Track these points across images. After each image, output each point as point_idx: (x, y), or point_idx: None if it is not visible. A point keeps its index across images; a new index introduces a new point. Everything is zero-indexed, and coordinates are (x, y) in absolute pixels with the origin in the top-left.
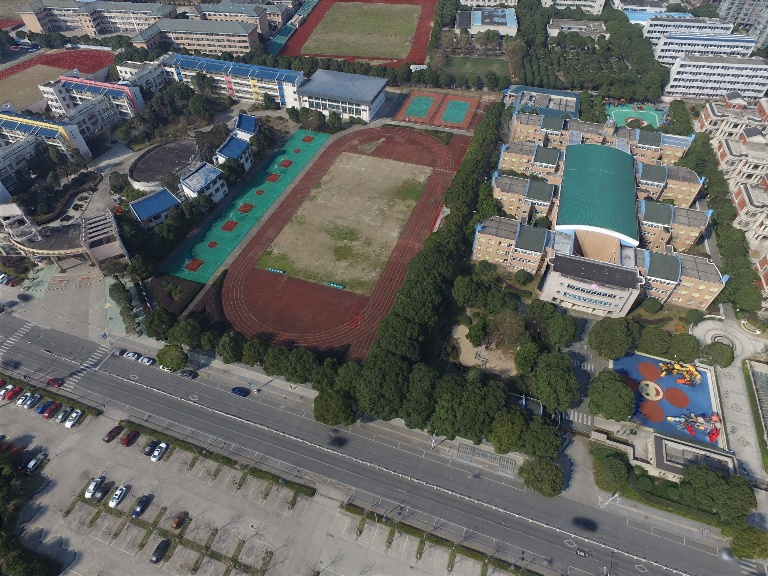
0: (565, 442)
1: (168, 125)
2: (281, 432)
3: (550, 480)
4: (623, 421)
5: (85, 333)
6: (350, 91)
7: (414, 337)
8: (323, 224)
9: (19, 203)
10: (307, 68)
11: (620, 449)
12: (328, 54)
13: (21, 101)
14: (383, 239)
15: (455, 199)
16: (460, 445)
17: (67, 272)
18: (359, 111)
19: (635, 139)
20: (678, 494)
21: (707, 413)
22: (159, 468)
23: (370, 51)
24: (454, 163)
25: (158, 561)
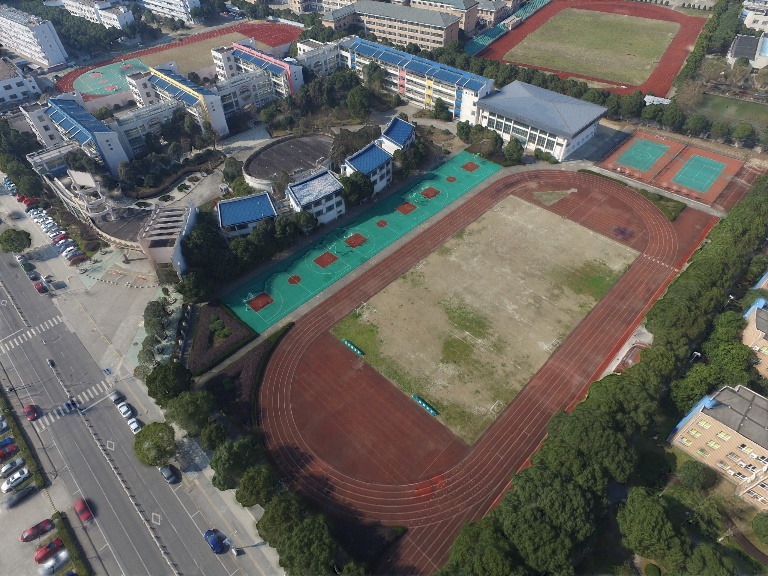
0: None
1: (319, 115)
2: None
3: None
4: None
5: (100, 353)
6: (548, 115)
7: None
8: (445, 295)
9: (127, 170)
10: (502, 77)
11: None
12: (536, 65)
13: (201, 64)
14: (525, 349)
15: (668, 324)
16: None
17: (130, 264)
18: (552, 144)
19: None
20: None
21: None
22: None
23: (592, 69)
24: (677, 253)
25: None
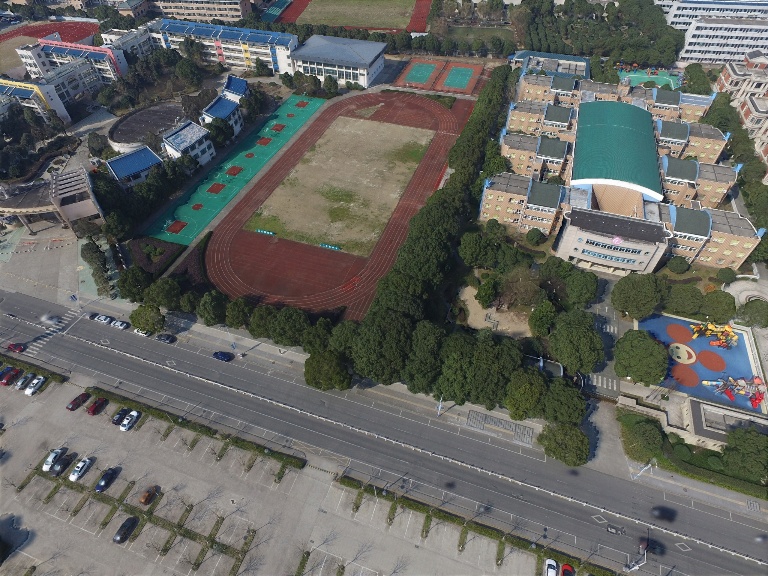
0: (588, 408)
1: (154, 91)
2: (268, 399)
3: (575, 447)
4: (653, 385)
5: (53, 296)
6: (347, 54)
7: (417, 294)
8: (317, 186)
9: None
10: (302, 35)
11: (651, 415)
12: None
13: None
14: (382, 200)
15: (460, 158)
16: (470, 412)
17: (37, 235)
18: (356, 76)
19: (652, 98)
20: (721, 464)
21: (747, 377)
22: (129, 438)
23: (368, 22)
24: (458, 126)
25: (123, 541)
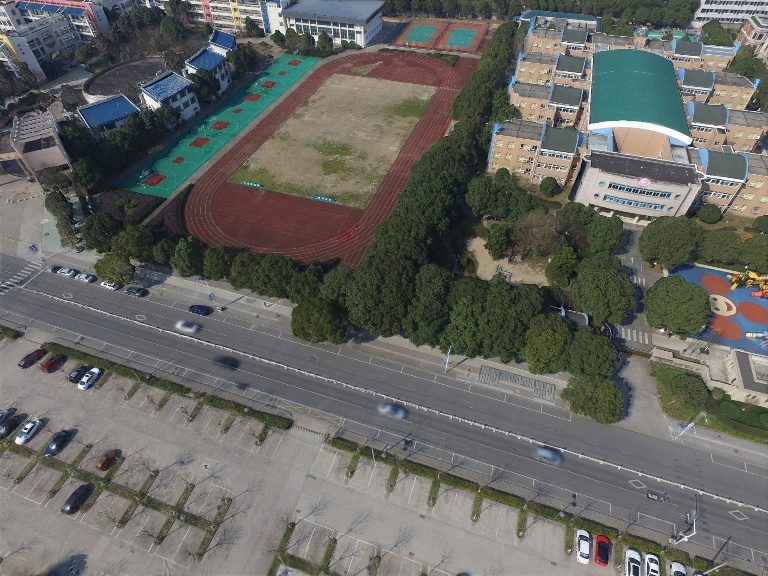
0: None
1: (137, 51)
2: (250, 354)
3: (607, 401)
4: (690, 338)
5: (13, 250)
6: (342, 10)
7: (420, 238)
8: (310, 139)
9: None
10: None
11: (691, 370)
12: None
13: None
14: (381, 153)
15: (465, 107)
16: (482, 367)
17: (0, 188)
18: (353, 34)
19: (671, 50)
20: None
21: None
22: (88, 397)
23: None
24: (462, 83)
25: (73, 511)
